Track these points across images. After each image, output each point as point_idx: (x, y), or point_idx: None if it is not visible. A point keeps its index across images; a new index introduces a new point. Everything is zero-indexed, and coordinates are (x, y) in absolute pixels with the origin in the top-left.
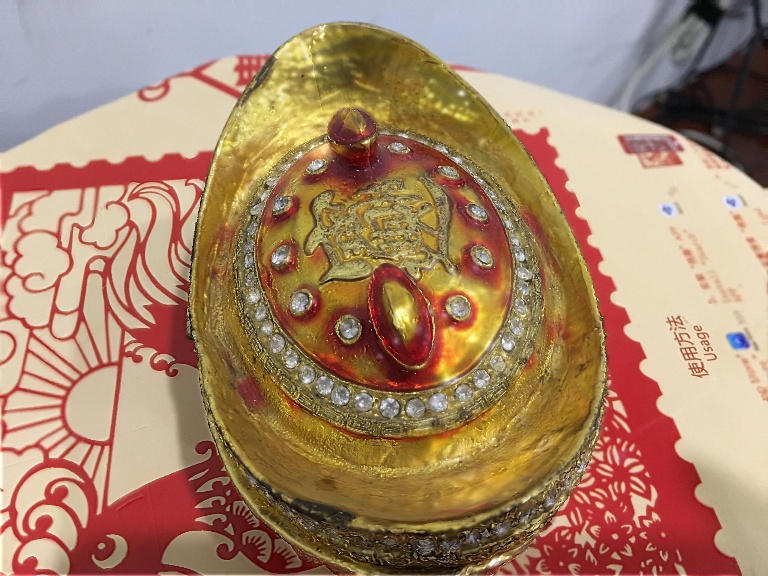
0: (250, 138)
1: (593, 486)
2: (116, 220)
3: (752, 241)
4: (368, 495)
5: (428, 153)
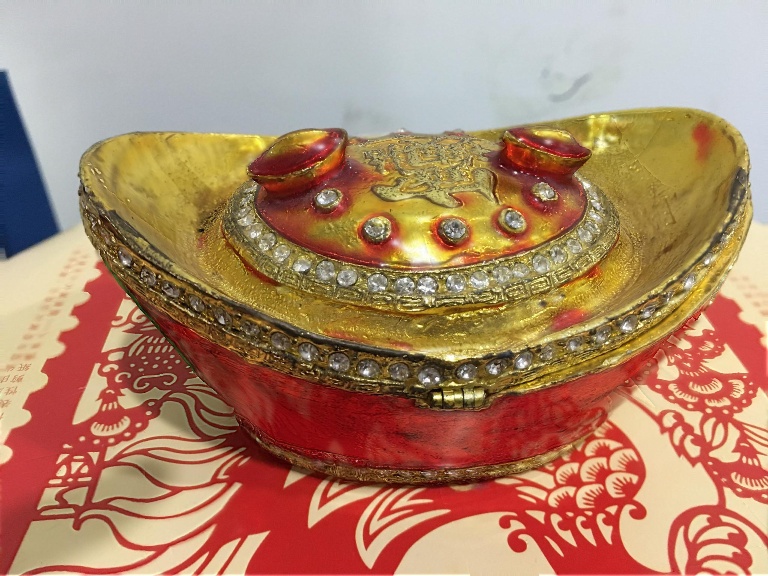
0: None
1: None
2: None
3: None
4: (677, 222)
5: None
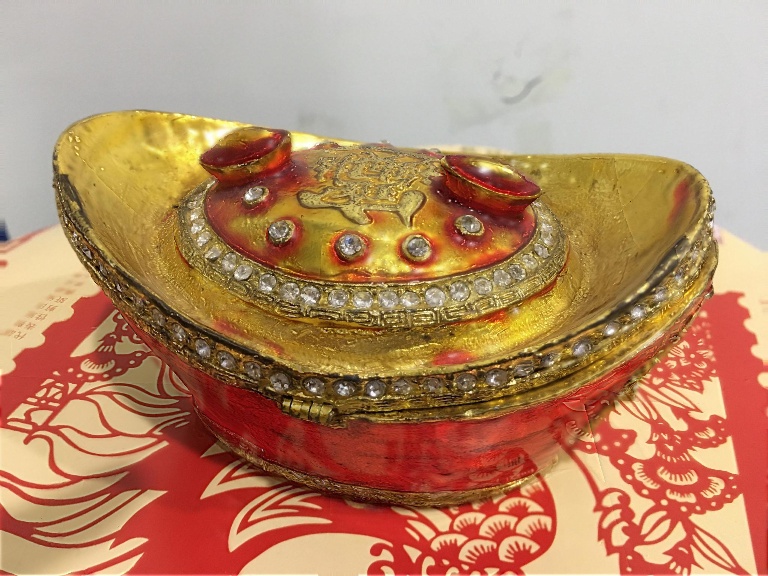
0: (124, 256)
1: None
2: None
3: None
4: None
5: None
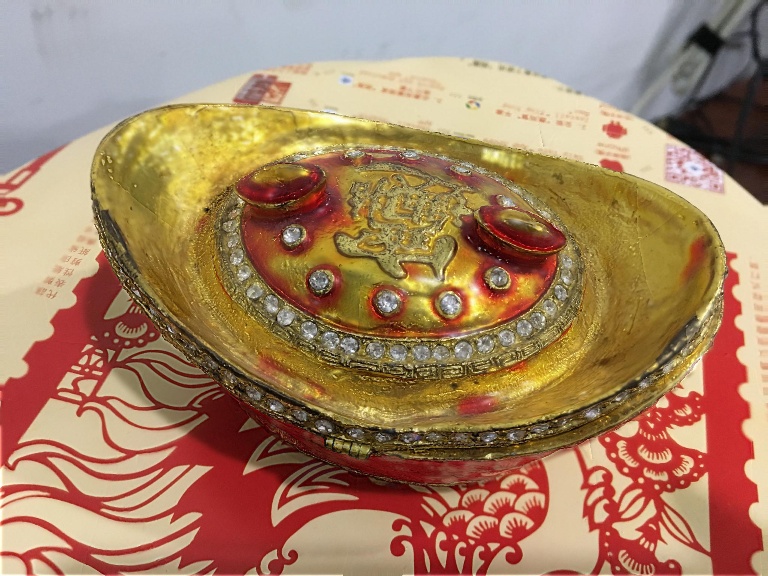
0: (171, 293)
1: None
2: (10, 573)
3: (386, 90)
4: (630, 335)
5: (313, 161)
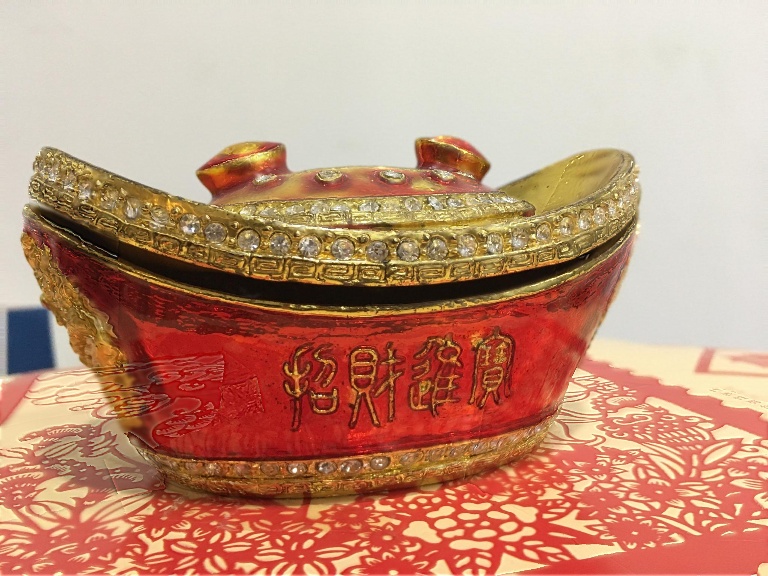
0: None
1: (204, 571)
2: None
3: None
4: None
5: (479, 185)
